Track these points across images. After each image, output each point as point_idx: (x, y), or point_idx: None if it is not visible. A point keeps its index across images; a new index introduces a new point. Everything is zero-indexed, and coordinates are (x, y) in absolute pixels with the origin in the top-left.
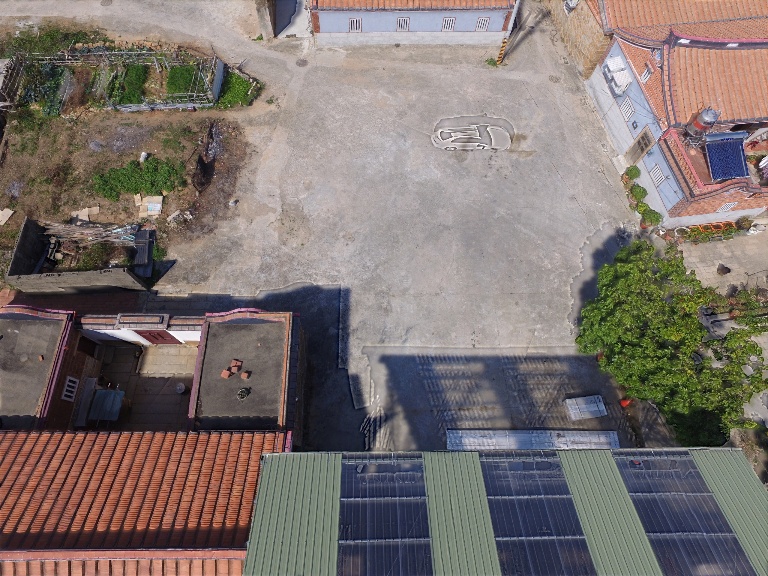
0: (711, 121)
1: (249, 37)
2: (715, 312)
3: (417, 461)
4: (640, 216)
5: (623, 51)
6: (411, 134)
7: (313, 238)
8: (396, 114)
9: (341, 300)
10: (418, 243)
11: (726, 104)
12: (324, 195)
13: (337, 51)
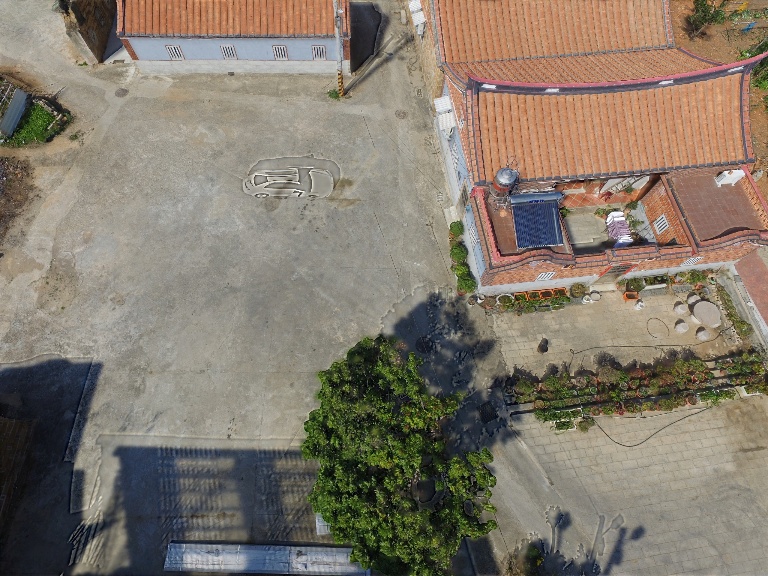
0: (506, 183)
1: (76, 62)
2: (517, 401)
3: None
4: None
5: (448, 90)
6: (221, 178)
7: (77, 300)
8: (210, 154)
9: (88, 377)
10: (195, 309)
11: (543, 158)
12: (103, 249)
13: (163, 80)
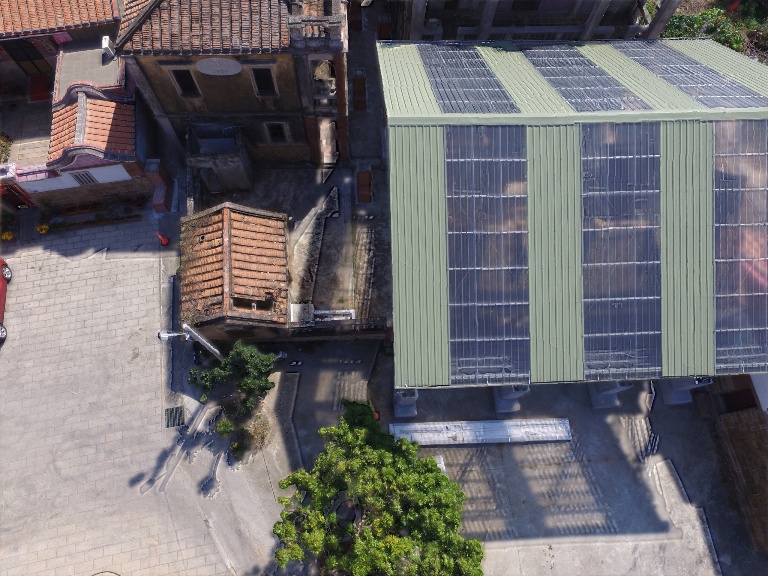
0: None
1: None
2: None
3: (721, 365)
4: None
5: None
6: None
7: None
8: None
9: None
10: None
11: None
12: None
13: None
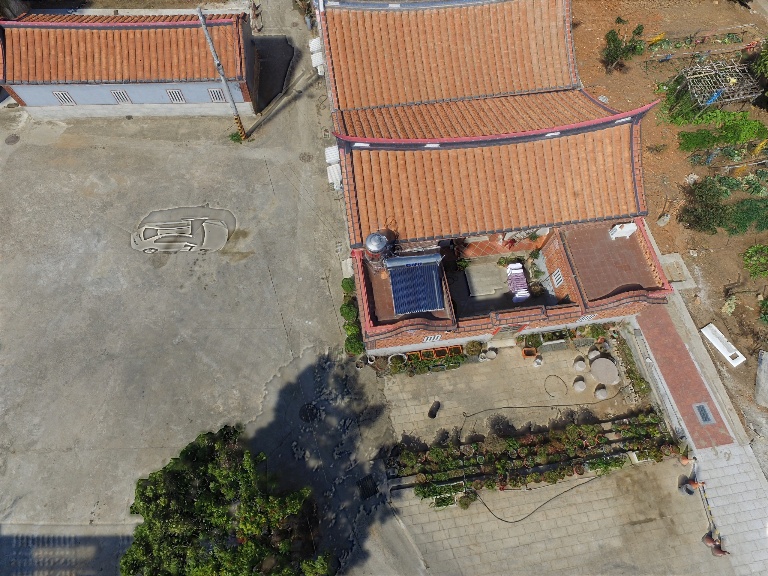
0: (374, 250)
1: None
2: (399, 475)
3: None
4: None
5: None
6: (109, 232)
7: None
8: (100, 206)
9: None
10: (68, 379)
11: (424, 217)
12: None
13: (57, 125)
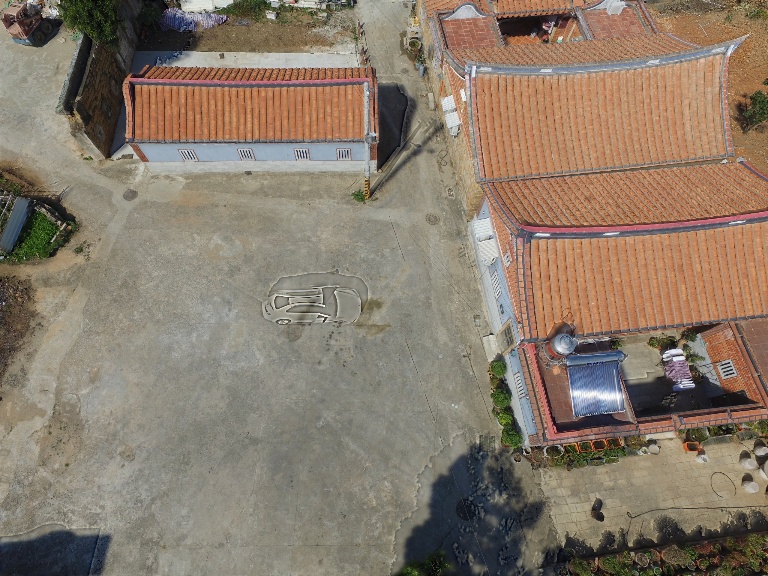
0: (565, 353)
1: (81, 155)
2: None
3: None
4: (502, 427)
5: (490, 215)
6: (239, 300)
7: (82, 455)
8: (227, 270)
9: (95, 554)
10: (213, 465)
11: (601, 310)
12: (111, 390)
13: (175, 180)
